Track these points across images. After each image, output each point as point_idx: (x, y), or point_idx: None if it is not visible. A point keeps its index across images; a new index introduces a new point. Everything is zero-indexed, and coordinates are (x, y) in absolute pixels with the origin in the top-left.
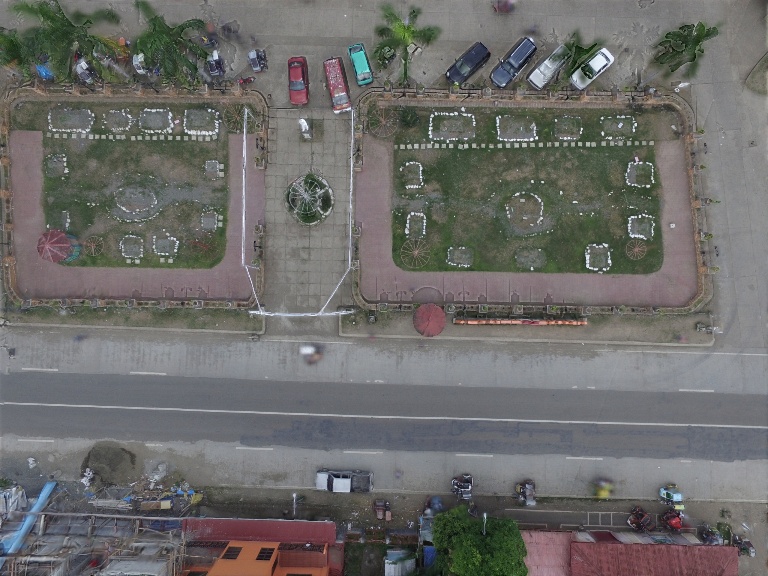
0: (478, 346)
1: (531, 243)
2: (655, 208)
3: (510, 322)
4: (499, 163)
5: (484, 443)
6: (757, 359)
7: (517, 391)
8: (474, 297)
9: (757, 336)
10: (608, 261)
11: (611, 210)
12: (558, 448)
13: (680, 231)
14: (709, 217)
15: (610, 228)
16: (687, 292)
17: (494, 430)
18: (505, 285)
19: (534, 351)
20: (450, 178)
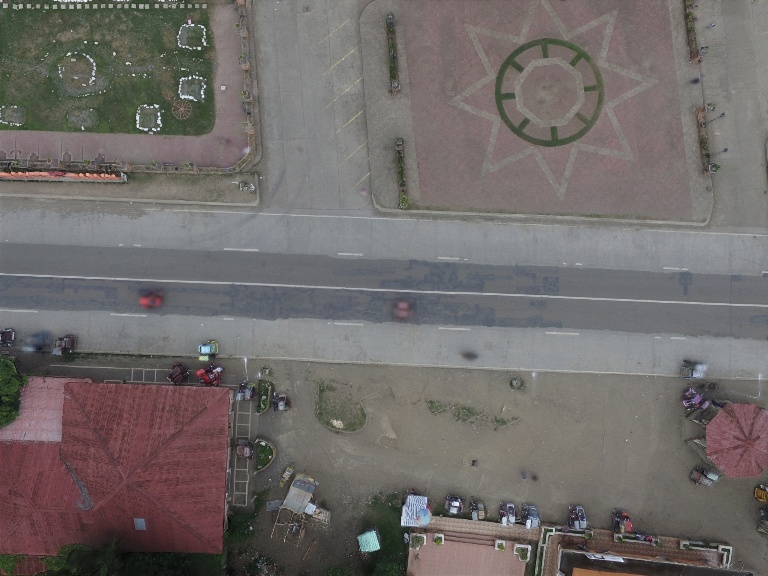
0: (27, 203)
1: (84, 103)
2: (207, 70)
3: (38, 174)
4: (54, 24)
5: (29, 299)
6: (302, 220)
7: (64, 248)
8: (26, 156)
9: (304, 197)
10: (157, 121)
11: (163, 72)
12: (103, 305)
13: (232, 94)
14: (261, 80)
15: (162, 89)
16: (237, 154)
17: (39, 286)
18: (57, 144)
19: (82, 209)
20: (4, 38)
